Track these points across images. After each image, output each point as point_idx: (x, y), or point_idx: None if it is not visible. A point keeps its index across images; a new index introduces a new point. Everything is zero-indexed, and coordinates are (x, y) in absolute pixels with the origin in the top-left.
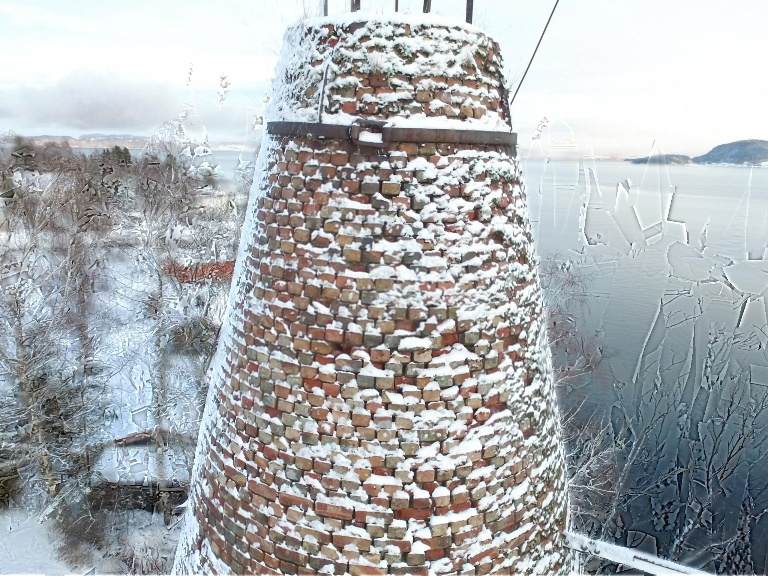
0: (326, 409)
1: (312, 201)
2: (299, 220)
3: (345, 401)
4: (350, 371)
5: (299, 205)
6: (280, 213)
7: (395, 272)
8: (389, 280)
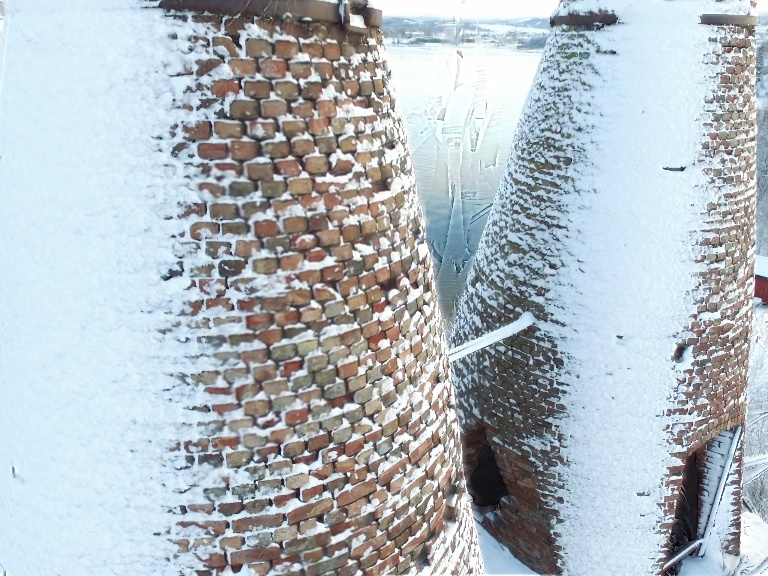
0: (395, 357)
1: (317, 114)
2: (308, 144)
3: (405, 338)
4: (402, 305)
5: (302, 123)
6: (270, 140)
7: (402, 182)
8: (401, 193)
